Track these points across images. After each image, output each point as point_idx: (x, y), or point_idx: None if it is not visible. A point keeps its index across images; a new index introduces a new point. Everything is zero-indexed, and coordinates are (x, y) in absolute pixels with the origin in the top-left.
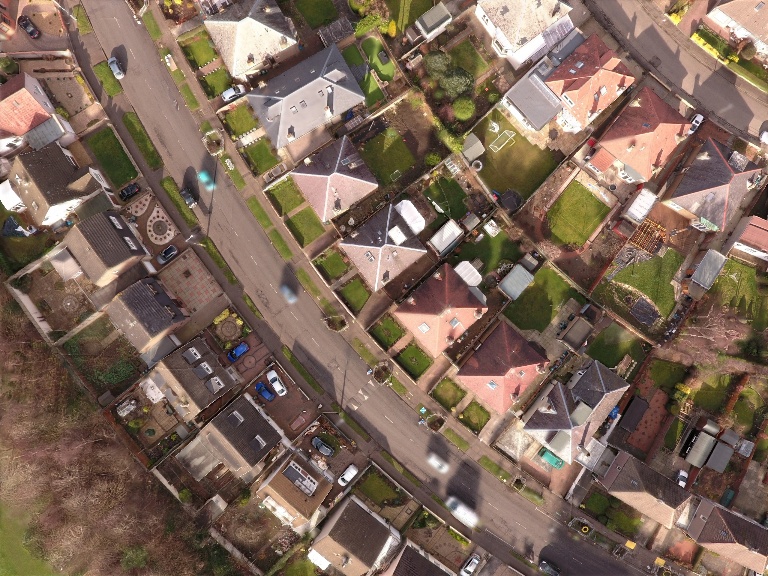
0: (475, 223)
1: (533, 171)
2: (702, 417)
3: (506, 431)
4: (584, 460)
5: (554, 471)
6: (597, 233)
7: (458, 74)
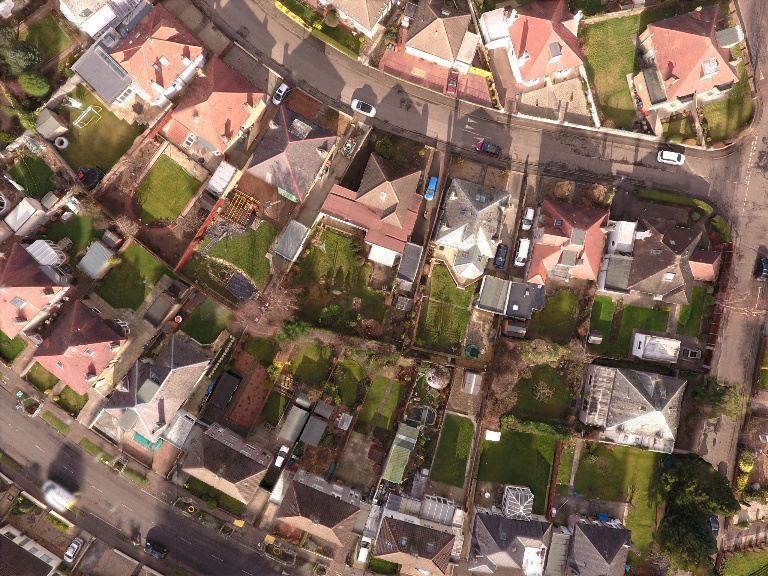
0: (53, 201)
1: (121, 146)
2: (301, 391)
3: (100, 412)
4: (173, 438)
5: (156, 451)
6: (190, 208)
7: (16, 48)
